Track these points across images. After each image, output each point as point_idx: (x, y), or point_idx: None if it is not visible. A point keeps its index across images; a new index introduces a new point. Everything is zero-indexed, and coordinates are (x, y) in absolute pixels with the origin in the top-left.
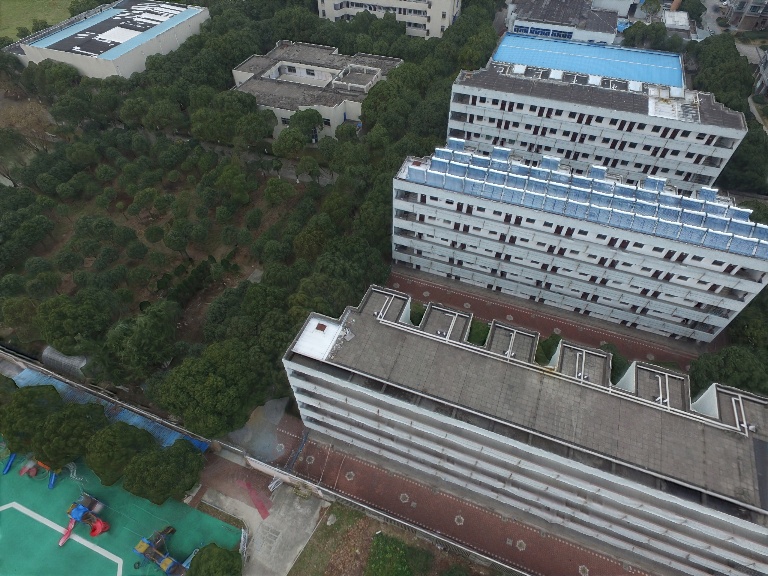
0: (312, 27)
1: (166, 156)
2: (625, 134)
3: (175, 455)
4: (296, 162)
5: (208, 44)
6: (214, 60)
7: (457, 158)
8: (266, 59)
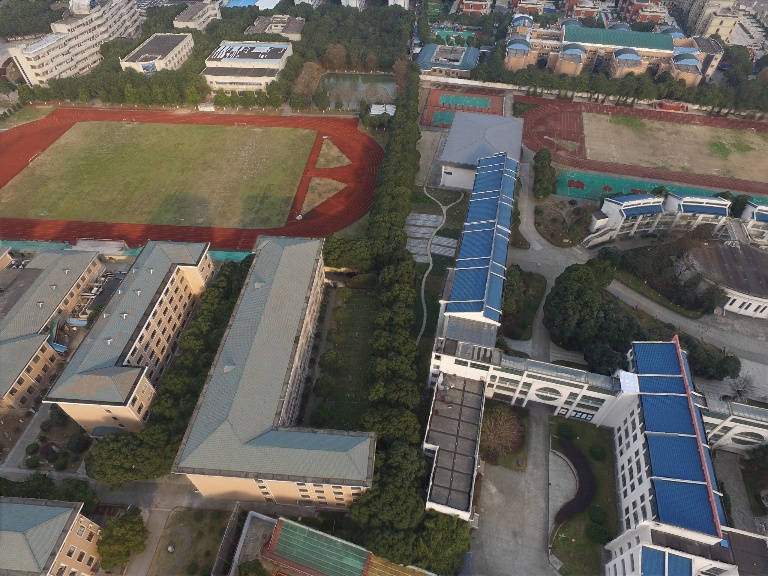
0: None
1: None
2: None
3: None
4: None
5: None
6: None
7: None
8: None
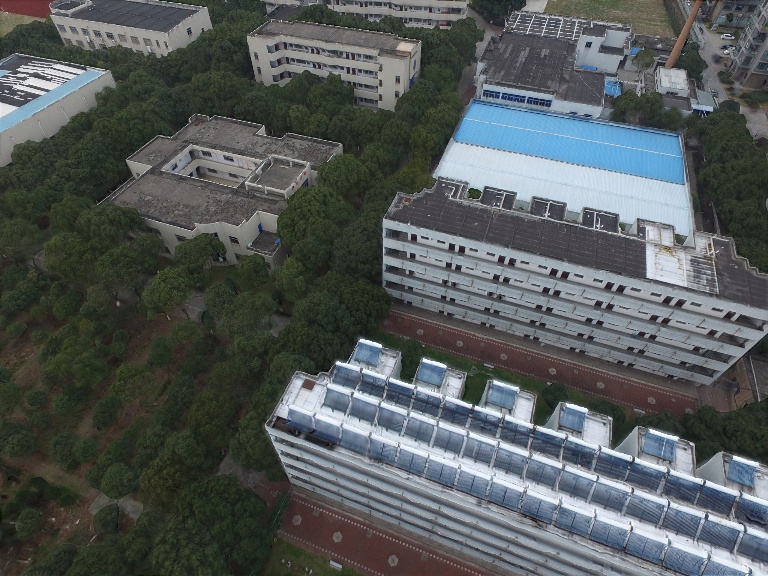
0: (236, 96)
1: (10, 299)
2: (615, 298)
3: None
4: (195, 291)
5: (96, 127)
6: (101, 148)
7: (367, 379)
8: (172, 142)
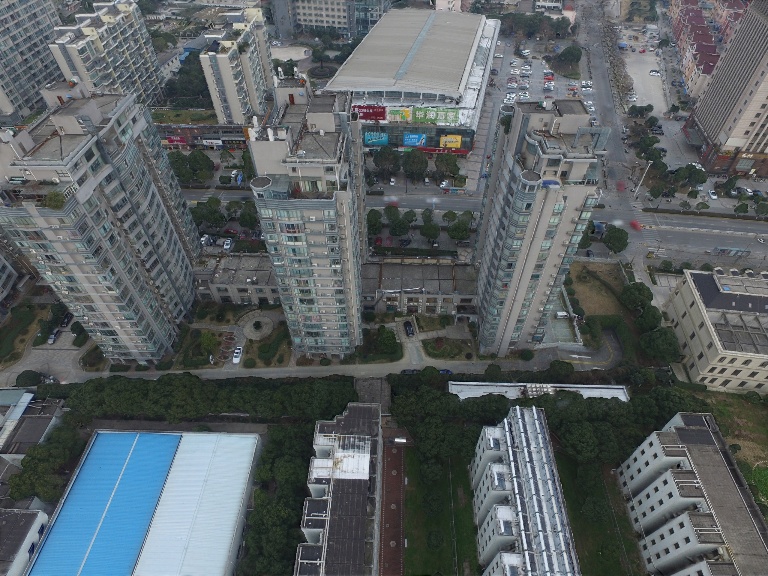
0: None
1: None
2: None
3: None
4: None
5: None
6: None
7: None
8: None
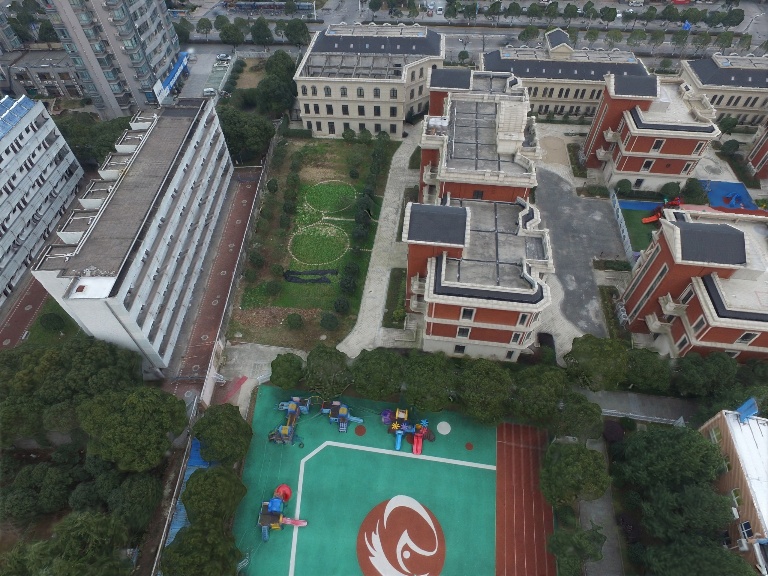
0: None
1: None
2: None
3: (208, 420)
4: None
5: None
6: None
7: None
8: None
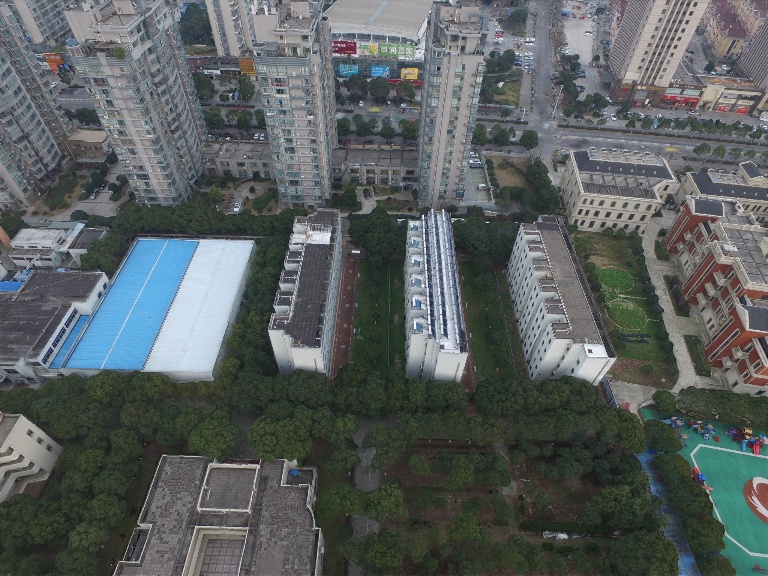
0: None
1: None
2: None
3: None
4: None
5: None
6: None
7: None
8: None
